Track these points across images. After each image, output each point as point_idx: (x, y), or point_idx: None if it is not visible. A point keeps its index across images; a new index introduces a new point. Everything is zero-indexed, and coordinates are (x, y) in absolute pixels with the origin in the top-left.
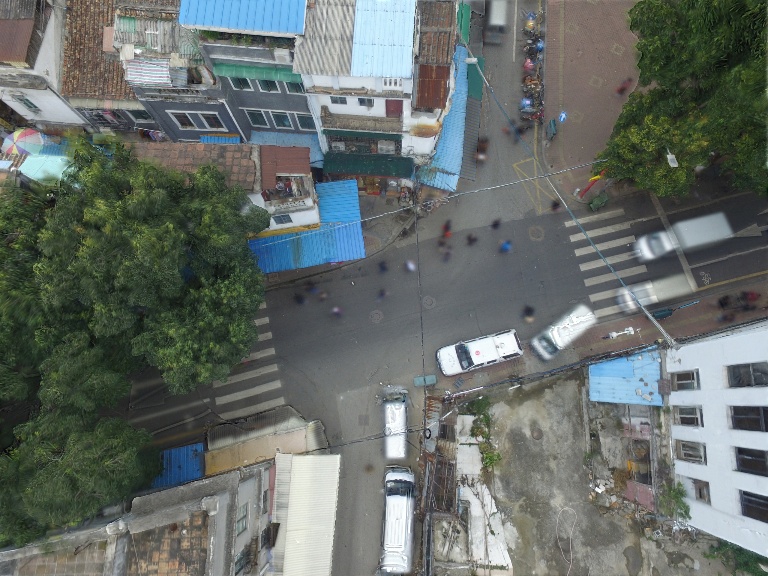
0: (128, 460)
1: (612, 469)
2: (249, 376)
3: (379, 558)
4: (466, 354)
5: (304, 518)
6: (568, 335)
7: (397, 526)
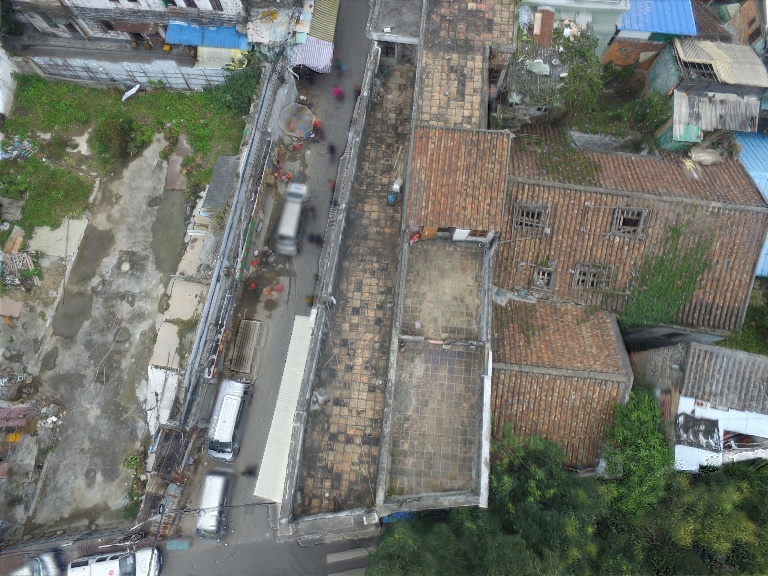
0: (368, 575)
1: (35, 435)
2: (358, 571)
3: (253, 388)
4: (126, 571)
5: (288, 445)
6: (24, 573)
7: (226, 416)
